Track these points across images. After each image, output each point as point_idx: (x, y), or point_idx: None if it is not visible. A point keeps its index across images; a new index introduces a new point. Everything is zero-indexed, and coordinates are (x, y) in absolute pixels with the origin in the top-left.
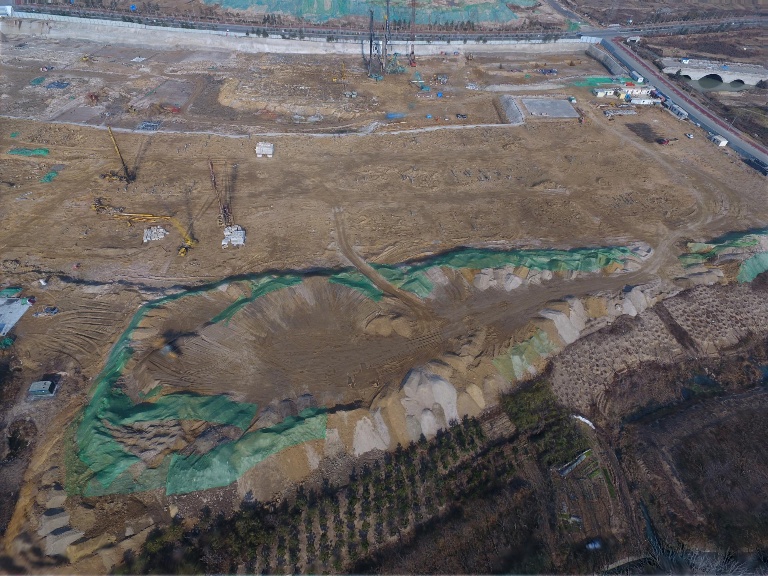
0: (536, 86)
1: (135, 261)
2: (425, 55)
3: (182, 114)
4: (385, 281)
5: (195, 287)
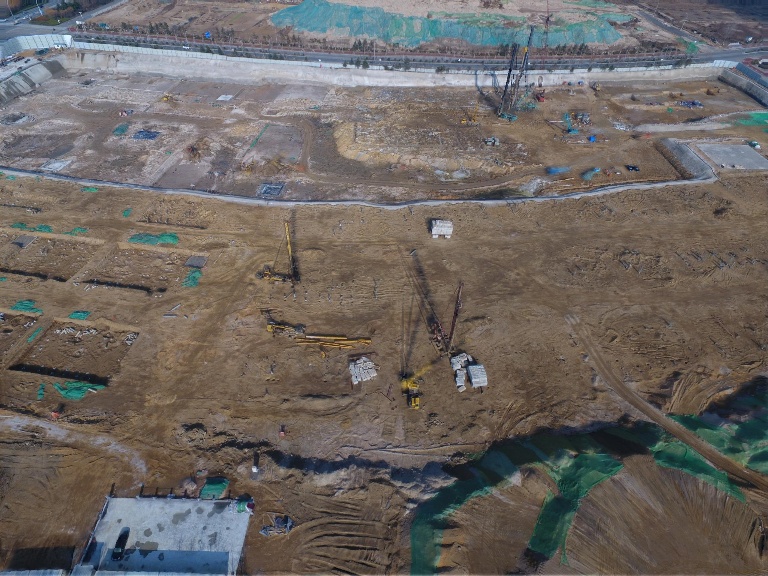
0: (698, 126)
1: (356, 419)
2: (546, 86)
3: (305, 172)
4: (716, 452)
5: (459, 467)
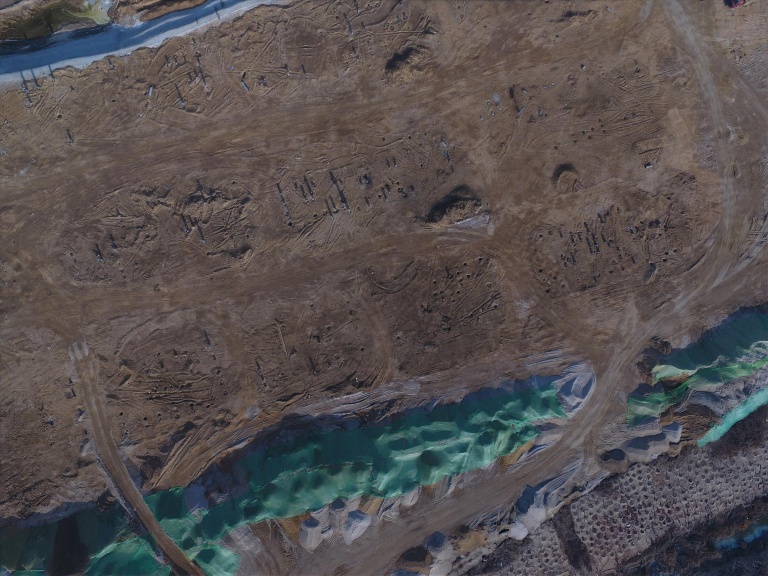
0: None
1: None
2: None
3: None
4: (173, 543)
5: None
